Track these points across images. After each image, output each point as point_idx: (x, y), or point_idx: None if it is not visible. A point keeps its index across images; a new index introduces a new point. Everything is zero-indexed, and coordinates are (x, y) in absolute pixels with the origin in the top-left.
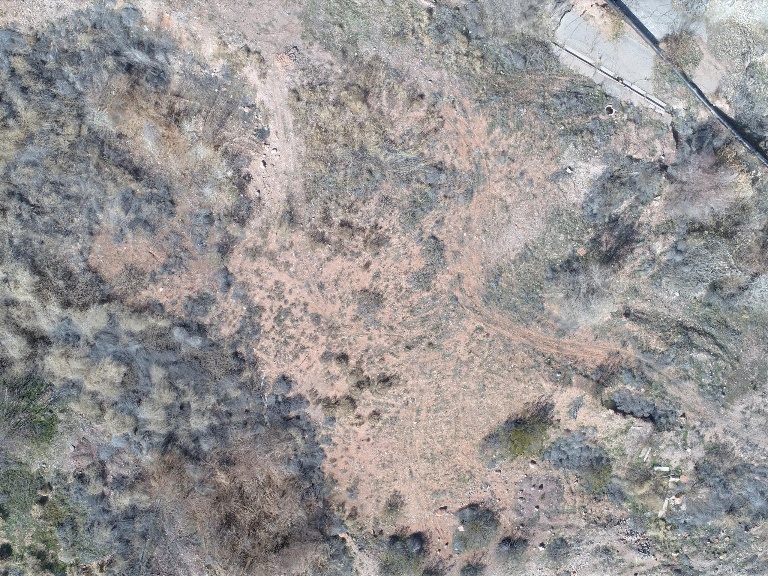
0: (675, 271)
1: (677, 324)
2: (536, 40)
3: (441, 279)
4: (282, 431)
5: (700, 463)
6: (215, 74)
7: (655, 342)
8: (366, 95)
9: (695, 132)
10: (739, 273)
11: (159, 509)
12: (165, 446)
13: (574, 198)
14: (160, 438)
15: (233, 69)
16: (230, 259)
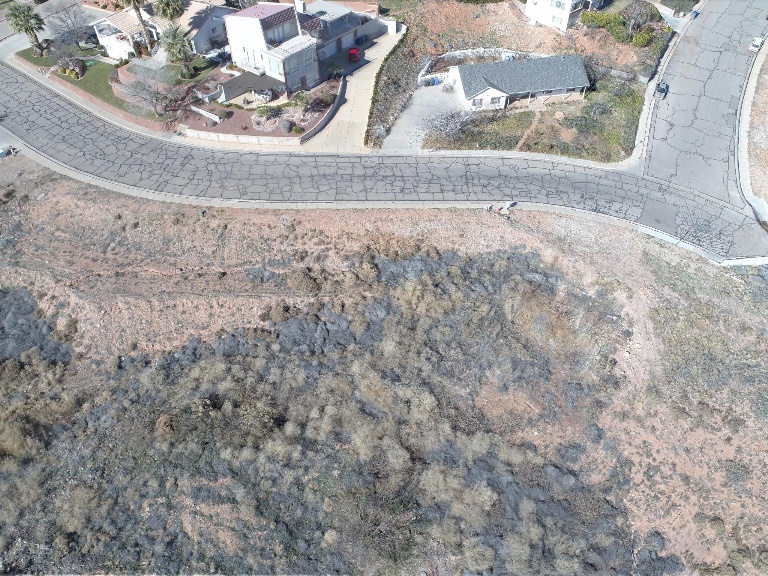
0: None
1: None
2: None
3: None
4: None
5: None
6: (590, 295)
7: None
8: None
9: None
10: None
11: None
12: None
13: None
14: None
15: (607, 291)
16: (599, 418)
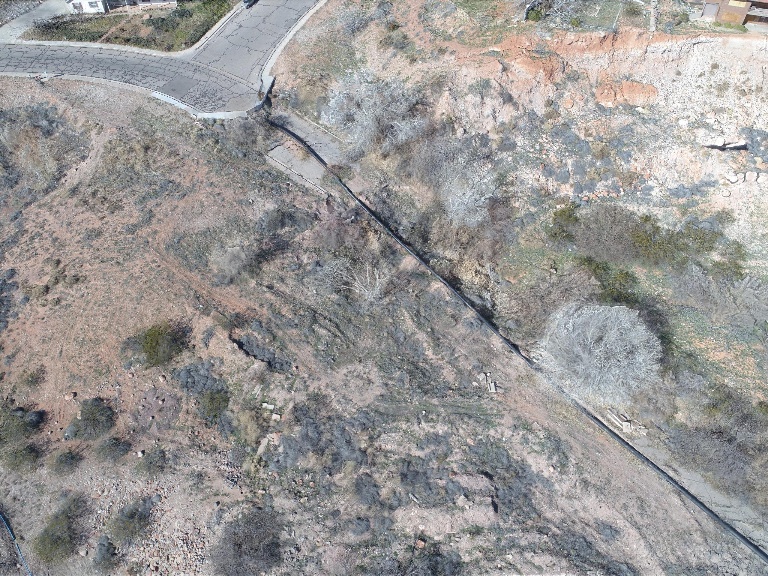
0: None
1: (308, 307)
2: None
3: (144, 230)
4: None
5: (300, 405)
6: (77, 134)
7: (286, 311)
8: (148, 149)
9: None
10: (367, 293)
11: None
12: None
13: (251, 217)
14: None
15: (86, 131)
16: (27, 208)
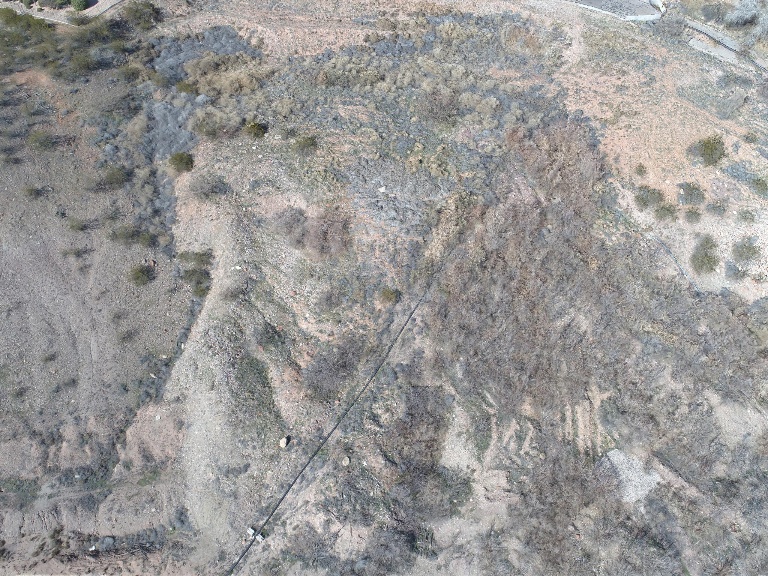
0: None
1: None
2: None
3: (655, 85)
4: None
5: None
6: (549, 31)
7: None
8: None
9: None
10: None
11: None
12: None
13: (712, 80)
14: None
15: (558, 27)
16: None
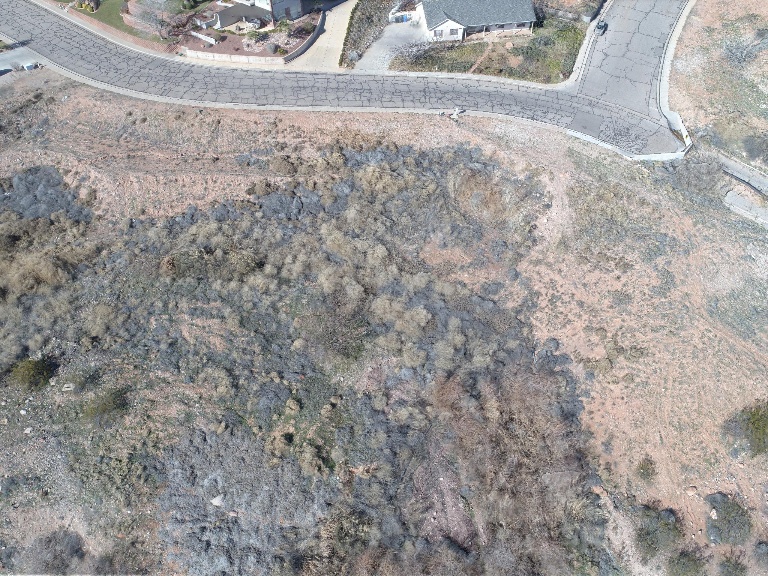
0: None
1: None
2: None
3: (674, 293)
4: (550, 377)
5: None
6: (520, 179)
7: None
8: None
9: None
10: None
11: (428, 434)
12: (447, 378)
13: (760, 275)
14: (443, 373)
15: (533, 175)
16: (518, 265)
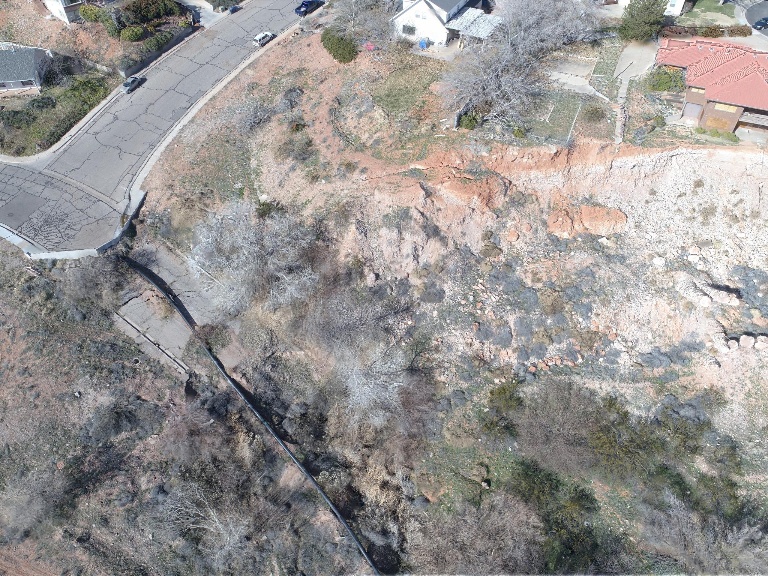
0: (153, 510)
1: (137, 568)
2: (103, 308)
3: None
4: None
5: None
6: None
7: None
8: None
9: (214, 396)
10: None
11: None
12: None
13: (76, 419)
14: None
15: None
16: None
